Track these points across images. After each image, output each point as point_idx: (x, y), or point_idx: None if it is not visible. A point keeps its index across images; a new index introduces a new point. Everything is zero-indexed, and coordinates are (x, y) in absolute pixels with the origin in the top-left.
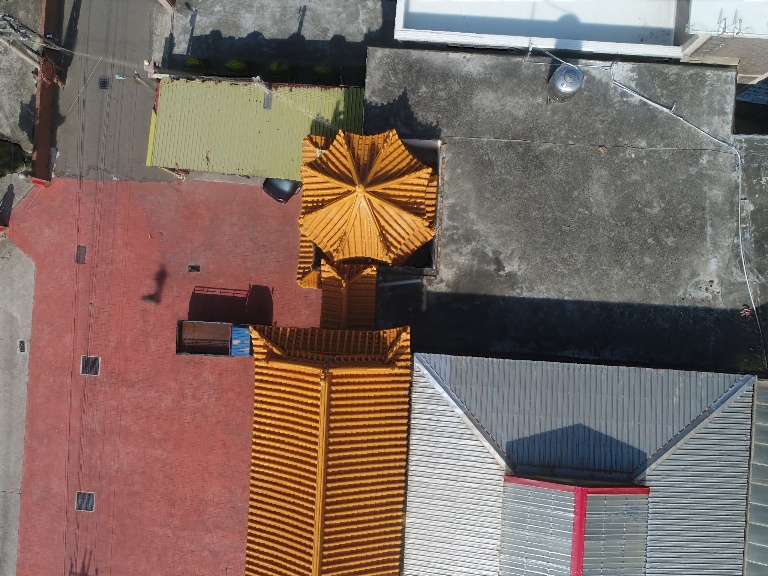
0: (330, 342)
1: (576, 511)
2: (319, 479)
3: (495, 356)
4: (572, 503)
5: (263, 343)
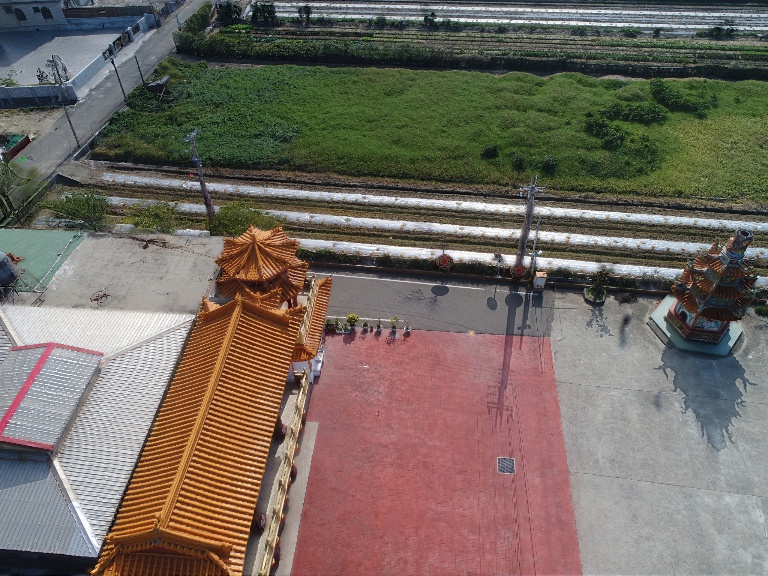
0: (169, 568)
1: (6, 424)
2: (190, 443)
3: (45, 565)
4: (6, 429)
5: (230, 567)
